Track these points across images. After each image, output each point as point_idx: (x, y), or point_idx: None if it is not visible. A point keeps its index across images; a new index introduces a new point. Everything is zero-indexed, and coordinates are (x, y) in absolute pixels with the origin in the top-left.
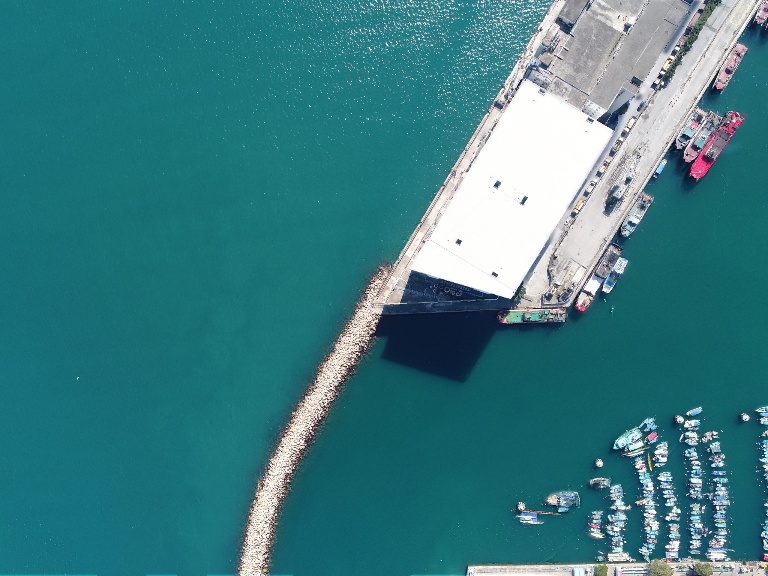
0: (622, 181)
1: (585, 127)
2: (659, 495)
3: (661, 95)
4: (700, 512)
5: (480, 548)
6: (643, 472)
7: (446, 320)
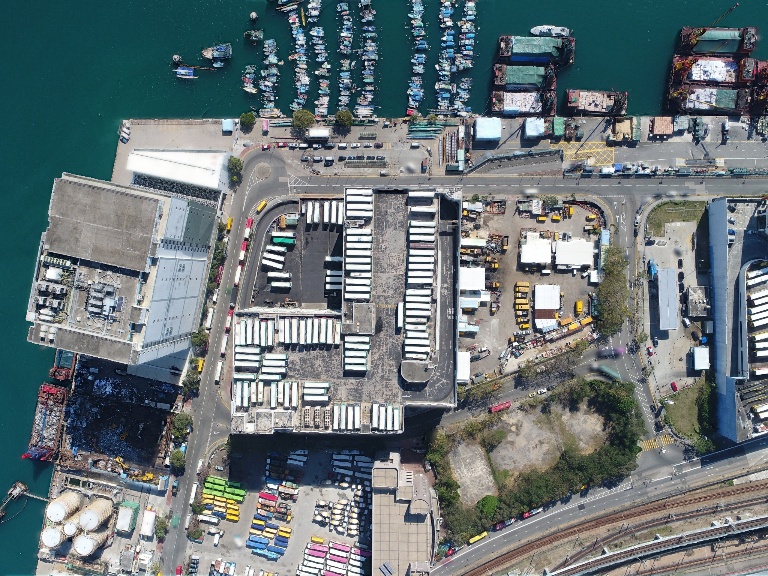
0: None
1: None
2: (311, 51)
3: None
4: (349, 67)
5: (139, 105)
6: (296, 27)
7: None
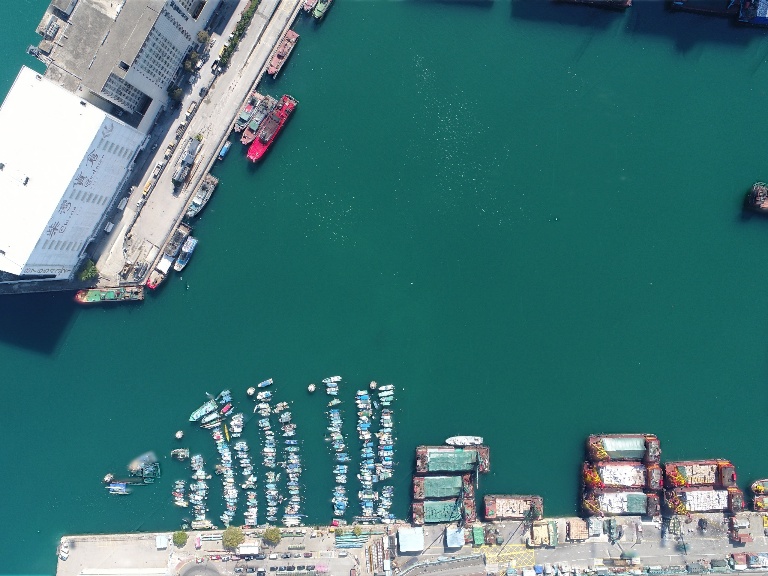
0: (178, 163)
1: (80, 110)
2: (237, 464)
3: (221, 80)
4: (274, 480)
5: (76, 519)
6: (221, 442)
7: (33, 300)
